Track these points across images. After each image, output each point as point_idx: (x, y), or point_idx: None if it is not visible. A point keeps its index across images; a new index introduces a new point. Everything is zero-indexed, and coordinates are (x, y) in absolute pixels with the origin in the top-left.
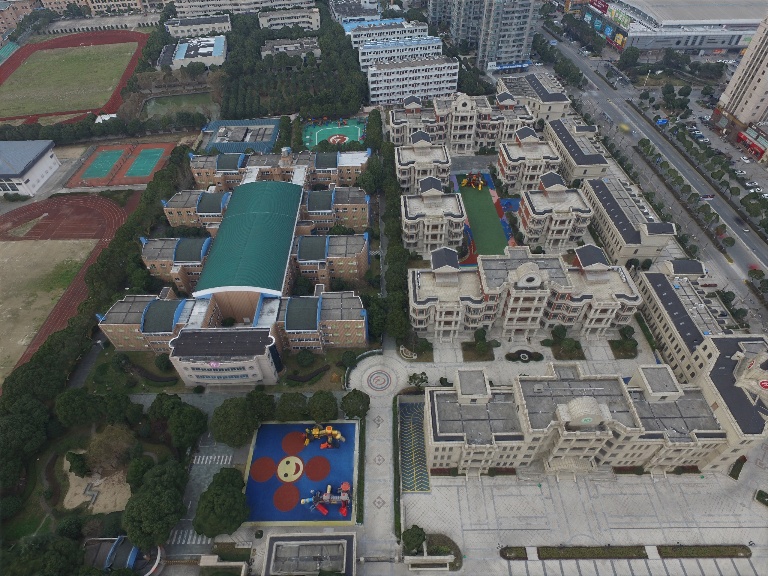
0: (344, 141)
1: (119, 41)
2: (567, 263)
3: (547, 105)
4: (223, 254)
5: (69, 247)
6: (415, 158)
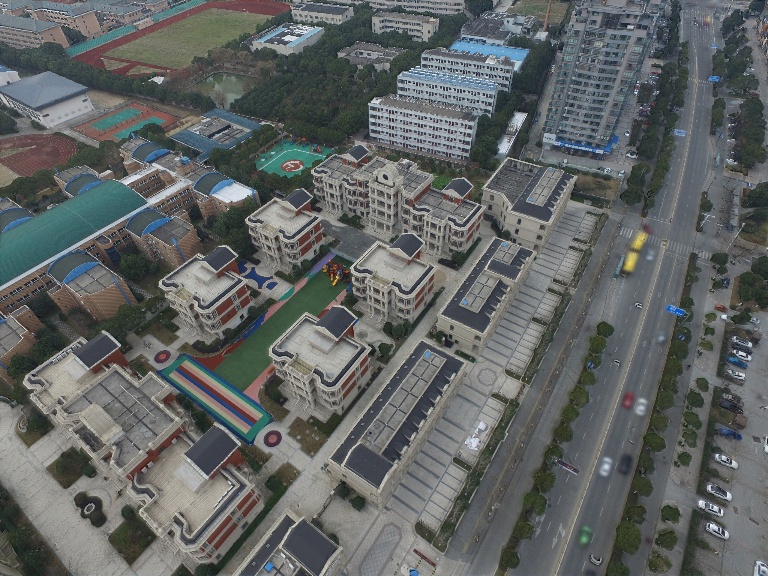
0: (294, 170)
1: (270, 13)
2: (288, 431)
3: (515, 216)
4: (1, 237)
5: (8, 179)
6: (273, 218)
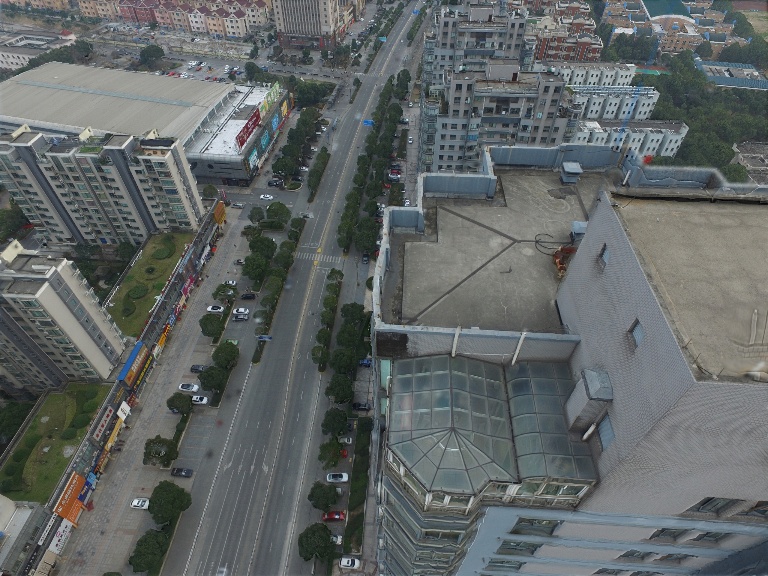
0: (636, 73)
1: None
2: None
3: None
4: (675, 0)
5: None
6: None
